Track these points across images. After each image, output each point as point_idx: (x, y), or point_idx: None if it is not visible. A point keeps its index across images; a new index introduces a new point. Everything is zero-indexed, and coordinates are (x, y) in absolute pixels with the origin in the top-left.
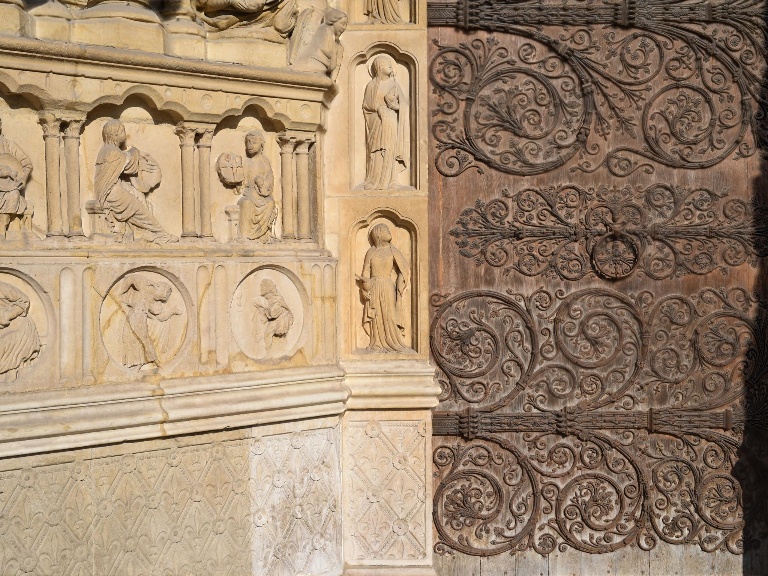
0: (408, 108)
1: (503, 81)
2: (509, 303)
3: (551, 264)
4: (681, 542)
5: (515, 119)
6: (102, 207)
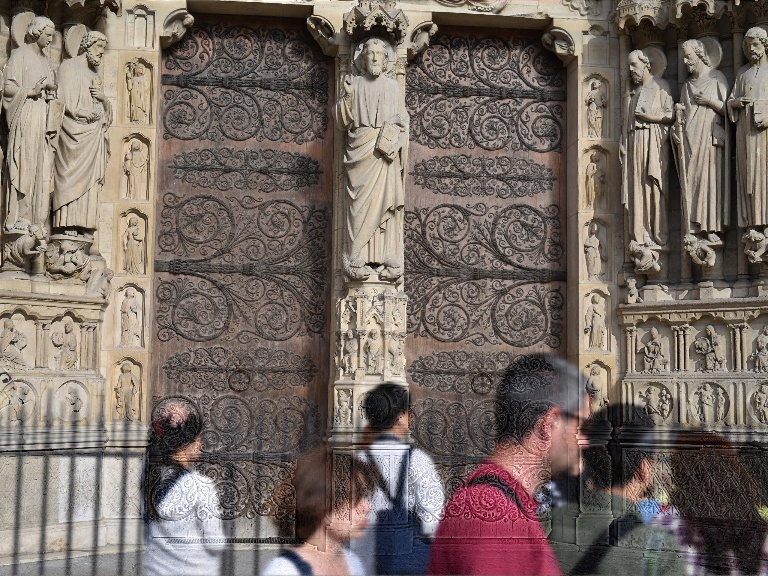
0: (142, 311)
1: (191, 298)
2: (190, 401)
3: (210, 383)
4: (266, 515)
5: (196, 315)
6: (2, 355)
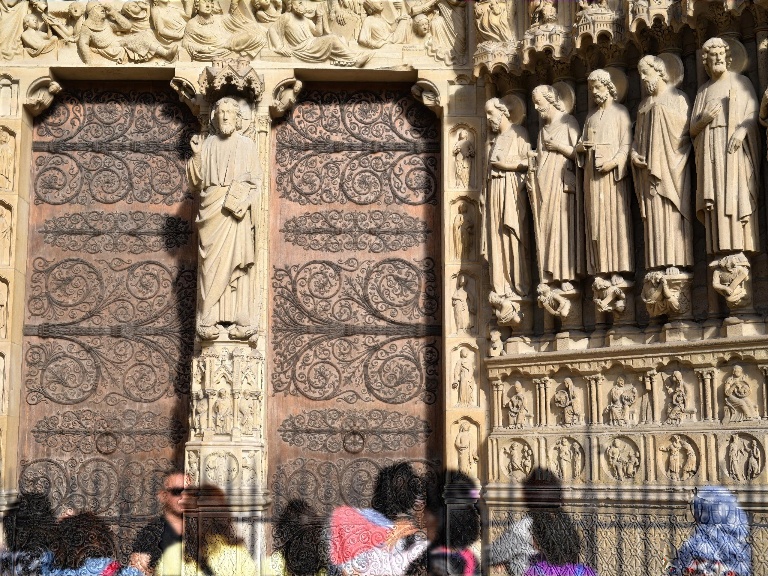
0: (3, 376)
1: (60, 361)
2: (57, 464)
3: (77, 446)
4: None
5: (64, 379)
6: None
